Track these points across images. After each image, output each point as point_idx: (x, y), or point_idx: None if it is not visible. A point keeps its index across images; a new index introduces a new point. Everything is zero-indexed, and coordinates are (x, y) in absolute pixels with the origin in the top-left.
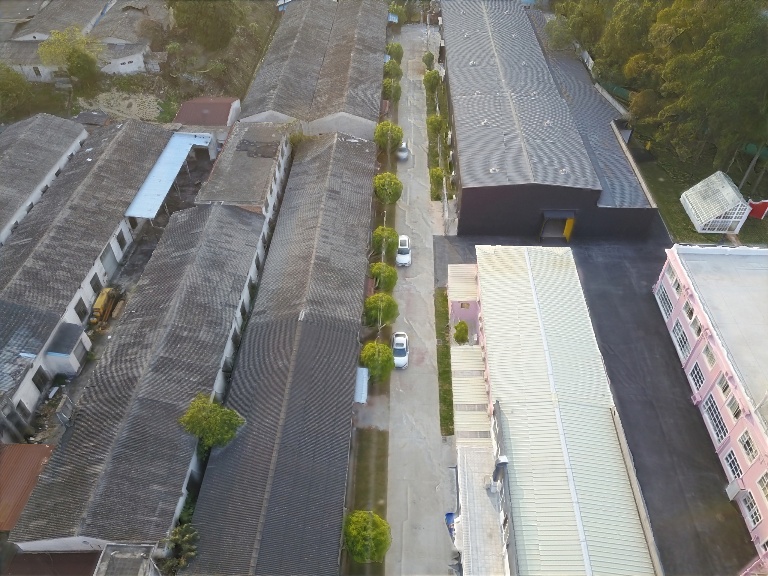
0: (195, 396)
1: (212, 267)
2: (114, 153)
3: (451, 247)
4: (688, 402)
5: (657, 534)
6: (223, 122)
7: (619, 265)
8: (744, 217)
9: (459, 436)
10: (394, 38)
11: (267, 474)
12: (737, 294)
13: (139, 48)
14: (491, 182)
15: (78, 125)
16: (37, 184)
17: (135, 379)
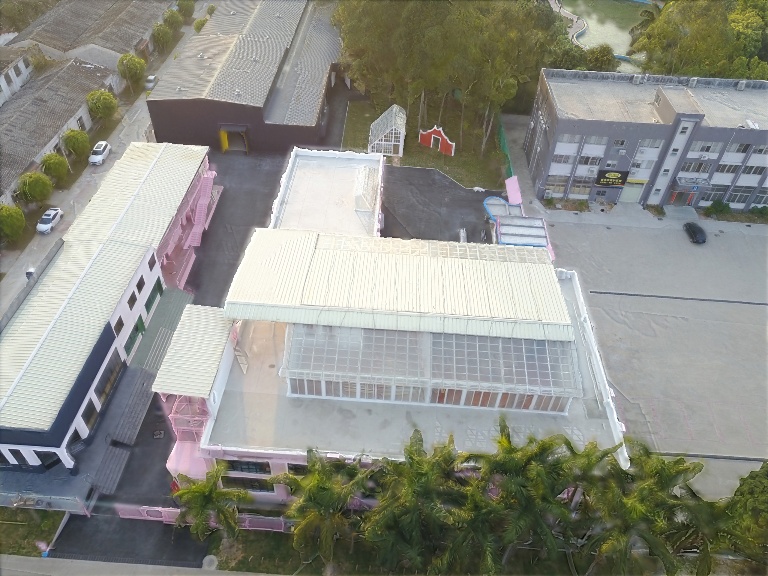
0: None
1: None
2: None
3: None
4: None
5: None
6: None
7: (280, 172)
8: (401, 141)
9: None
10: None
11: None
12: (321, 183)
13: None
14: (171, 97)
15: None
16: None
17: None
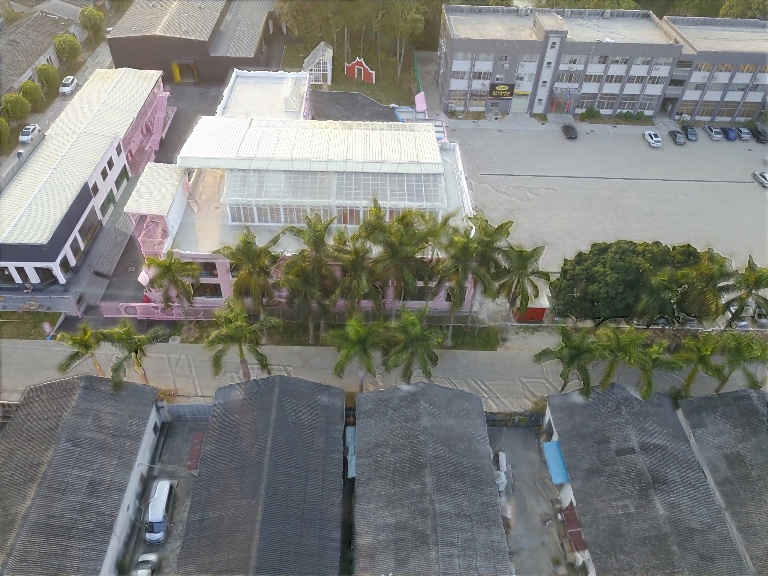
0: None
1: None
2: None
3: None
4: None
5: None
6: None
7: None
8: (329, 70)
9: None
10: None
11: None
12: (257, 94)
13: None
14: (128, 34)
15: None
16: None
17: None
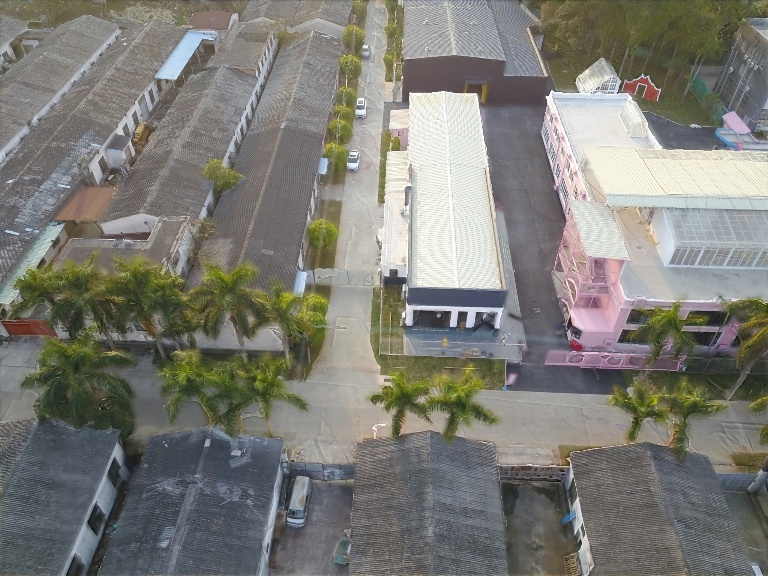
0: None
1: (220, 101)
2: (144, 39)
3: (397, 108)
4: (551, 189)
5: (514, 249)
6: (225, 27)
7: (519, 118)
8: (616, 88)
9: (387, 193)
10: None
11: (259, 195)
12: (588, 118)
13: None
14: (425, 55)
15: (114, 24)
16: (87, 58)
17: (171, 151)
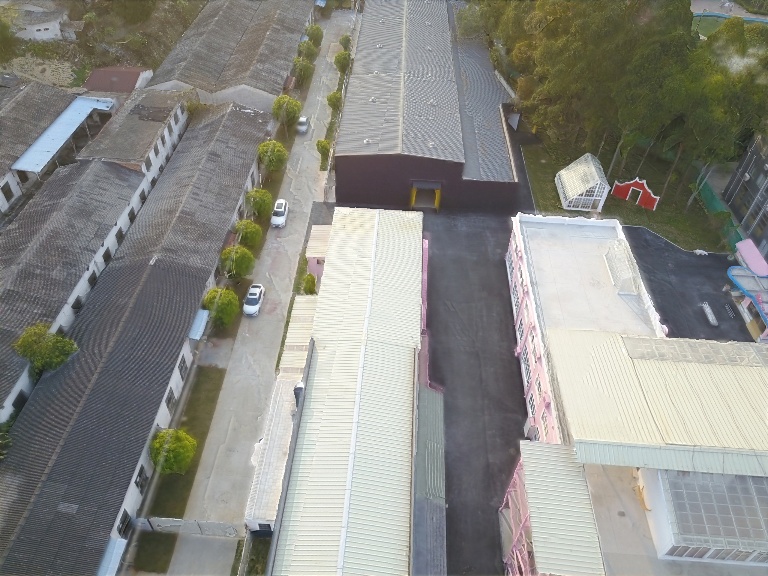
0: (35, 325)
1: (79, 215)
2: (11, 111)
3: (327, 212)
4: (511, 354)
5: (451, 463)
6: (130, 90)
7: (480, 234)
8: (604, 196)
9: (281, 371)
10: (322, 22)
11: (84, 392)
12: (564, 258)
13: (55, 16)
14: (362, 151)
15: None
16: None
17: None
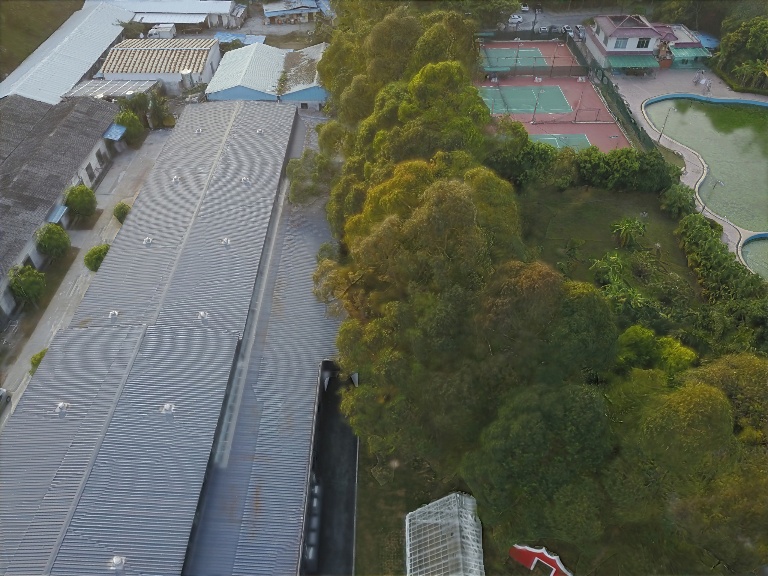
0: None
1: None
2: None
3: None
4: None
5: None
6: None
7: None
8: None
9: None
10: (125, 157)
11: None
12: None
13: None
14: None
15: None
16: None
17: None
